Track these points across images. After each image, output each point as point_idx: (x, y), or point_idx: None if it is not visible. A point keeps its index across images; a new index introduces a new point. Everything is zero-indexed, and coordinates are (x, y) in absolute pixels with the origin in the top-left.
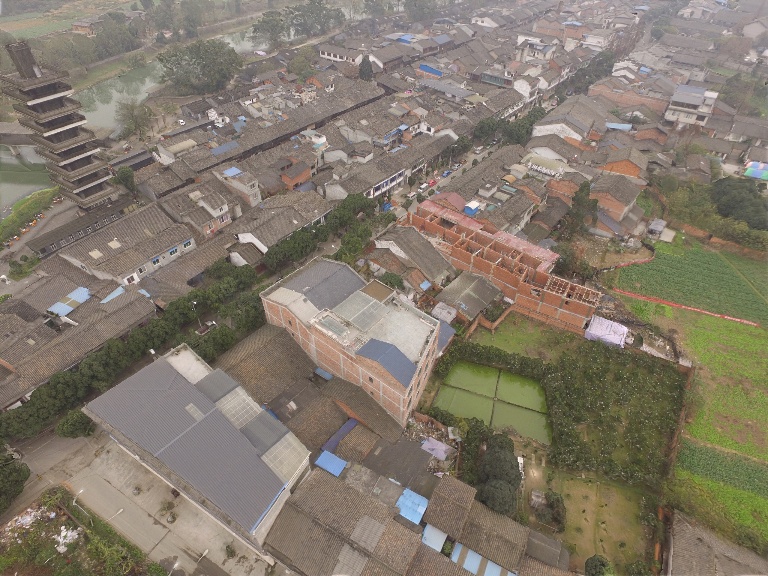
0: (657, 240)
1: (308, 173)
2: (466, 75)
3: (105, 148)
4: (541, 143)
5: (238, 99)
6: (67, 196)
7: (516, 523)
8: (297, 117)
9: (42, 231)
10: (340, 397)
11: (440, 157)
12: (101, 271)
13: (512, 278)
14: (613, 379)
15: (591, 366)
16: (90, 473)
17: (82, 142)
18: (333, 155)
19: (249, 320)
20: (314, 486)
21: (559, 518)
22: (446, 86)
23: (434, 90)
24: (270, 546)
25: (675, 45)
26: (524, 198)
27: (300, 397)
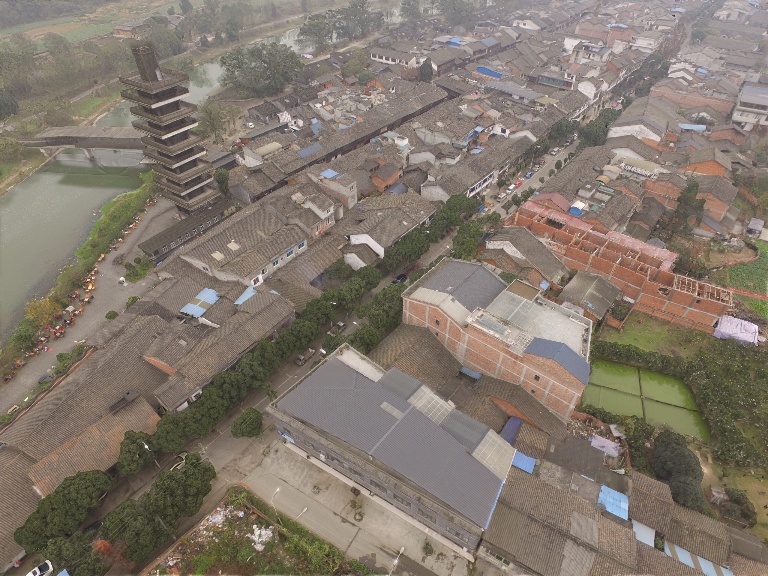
0: (757, 239)
1: (396, 175)
2: (522, 77)
3: None
4: (620, 144)
5: (308, 102)
6: (171, 198)
7: (710, 519)
8: (372, 119)
9: (145, 233)
10: (501, 396)
11: (519, 158)
12: (226, 272)
13: (636, 277)
14: (755, 377)
15: (731, 364)
16: (264, 472)
17: (194, 145)
18: (419, 157)
19: (388, 320)
20: (514, 483)
21: (750, 514)
22: (513, 88)
23: (501, 92)
24: (488, 542)
25: (719, 47)
26: (626, 198)
27: (456, 396)
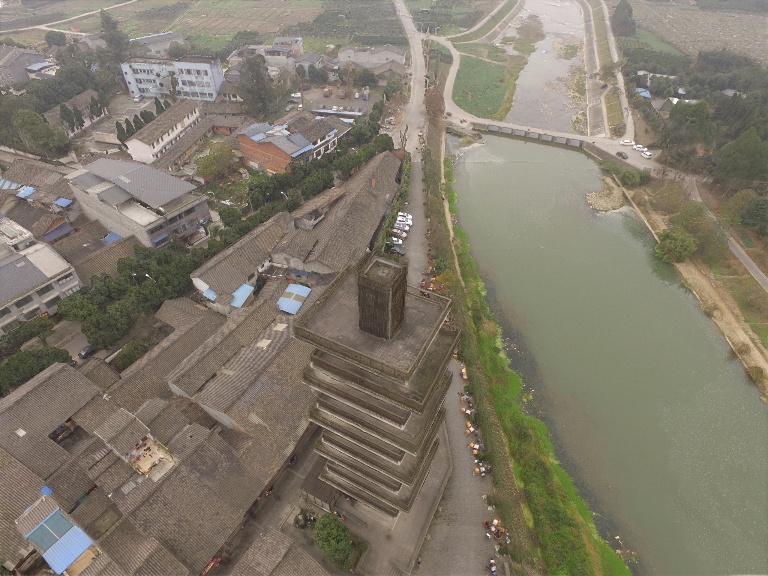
0: None
1: None
2: None
3: None
4: None
5: None
6: None
7: None
8: None
9: None
10: (44, 240)
11: None
12: None
13: None
14: None
15: None
16: None
17: None
18: None
19: None
20: None
21: None
22: None
23: None
24: None
25: None
26: None
27: None
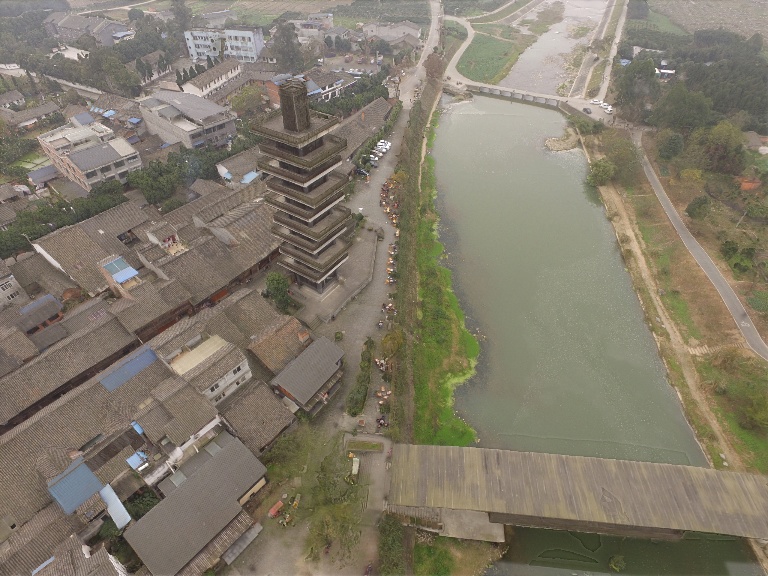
0: None
1: None
2: None
3: None
4: None
5: None
6: None
7: None
8: None
9: (369, 259)
10: None
11: None
12: None
13: None
14: None
15: None
16: None
17: None
18: None
19: None
20: None
21: None
22: None
23: None
24: None
25: None
26: None
27: None
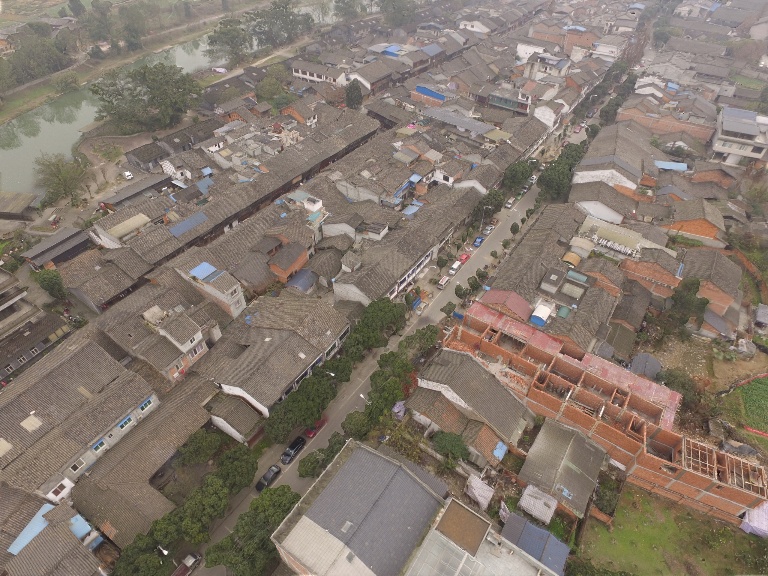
0: (767, 336)
1: (304, 256)
2: (470, 96)
3: (25, 221)
4: (589, 195)
5: (200, 144)
6: None
7: None
8: (279, 169)
9: None
10: None
11: (466, 217)
12: None
13: (628, 442)
14: None
15: None
16: None
17: None
18: (335, 228)
19: (255, 572)
20: None
21: None
22: (458, 118)
23: (443, 123)
24: None
25: (684, 50)
26: (604, 294)
27: None
